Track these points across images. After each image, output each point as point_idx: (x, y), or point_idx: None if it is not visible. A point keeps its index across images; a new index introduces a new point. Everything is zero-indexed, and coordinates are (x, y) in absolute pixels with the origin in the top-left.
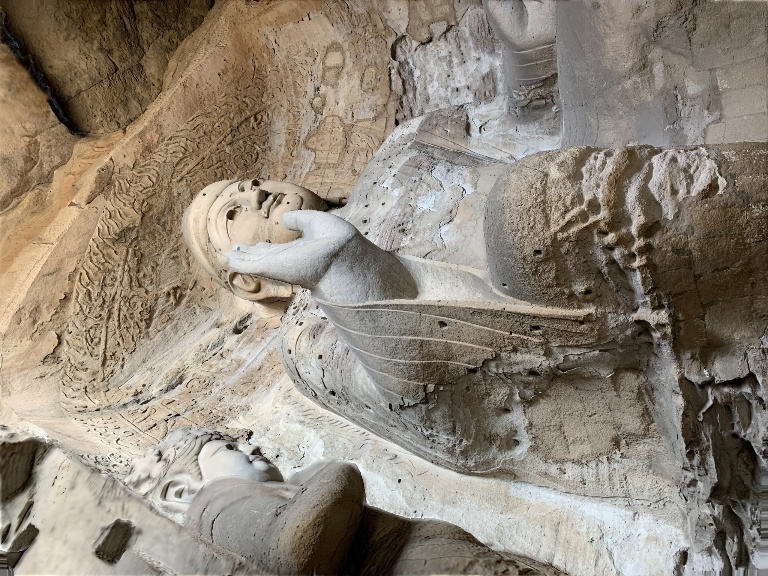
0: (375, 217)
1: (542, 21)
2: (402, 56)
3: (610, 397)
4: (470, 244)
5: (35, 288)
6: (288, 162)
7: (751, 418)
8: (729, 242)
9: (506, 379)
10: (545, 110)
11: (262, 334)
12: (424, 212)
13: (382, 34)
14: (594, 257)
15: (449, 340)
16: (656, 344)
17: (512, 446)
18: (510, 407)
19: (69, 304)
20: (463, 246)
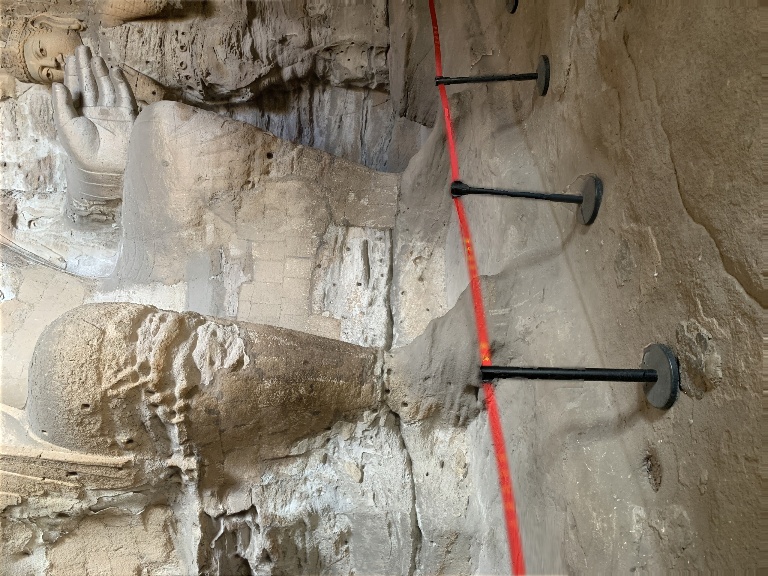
0: None
1: (113, 152)
2: None
3: (138, 531)
4: (2, 359)
5: None
6: None
7: (250, 540)
8: (247, 406)
9: (30, 523)
10: (105, 224)
11: None
12: None
13: None
14: (139, 412)
15: None
16: (184, 484)
17: None
18: (30, 551)
19: None
20: None
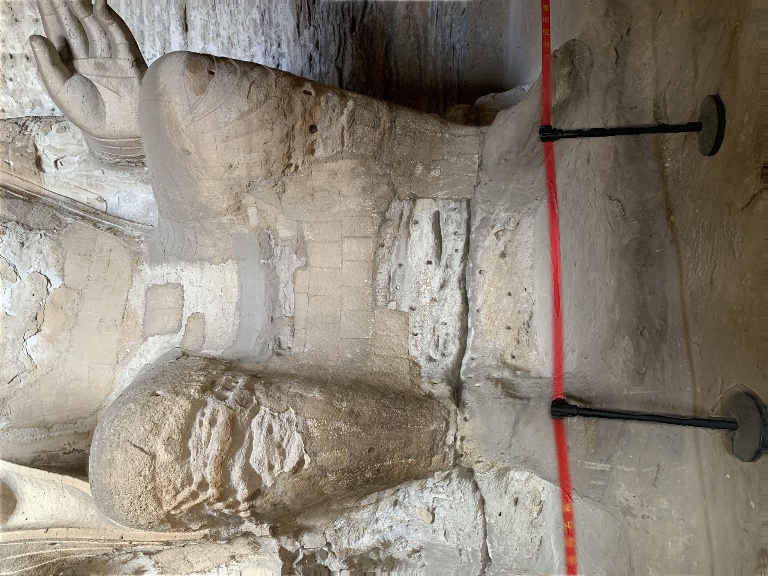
0: None
1: (123, 117)
2: None
3: None
4: (67, 362)
5: None
6: None
7: None
8: (312, 495)
9: None
10: (136, 167)
11: None
12: None
13: None
14: (206, 513)
15: (63, 549)
16: None
17: (141, 574)
18: (135, 558)
19: None
20: (59, 364)
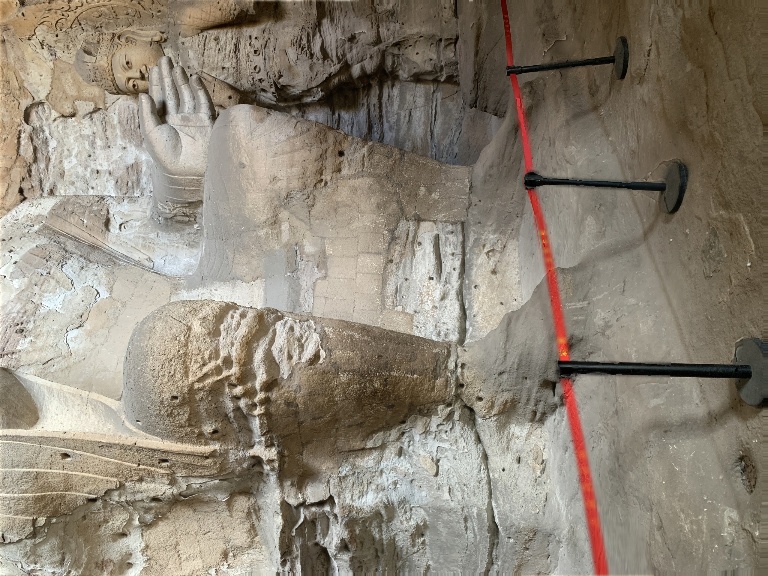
0: None
1: (194, 156)
2: (37, 122)
3: (224, 517)
4: (100, 354)
5: None
6: None
7: (328, 529)
8: (324, 399)
9: (127, 506)
10: (187, 225)
11: None
12: (49, 312)
13: (15, 93)
14: (223, 404)
15: (70, 471)
16: (266, 474)
17: (125, 570)
18: (128, 532)
19: None
20: (91, 355)
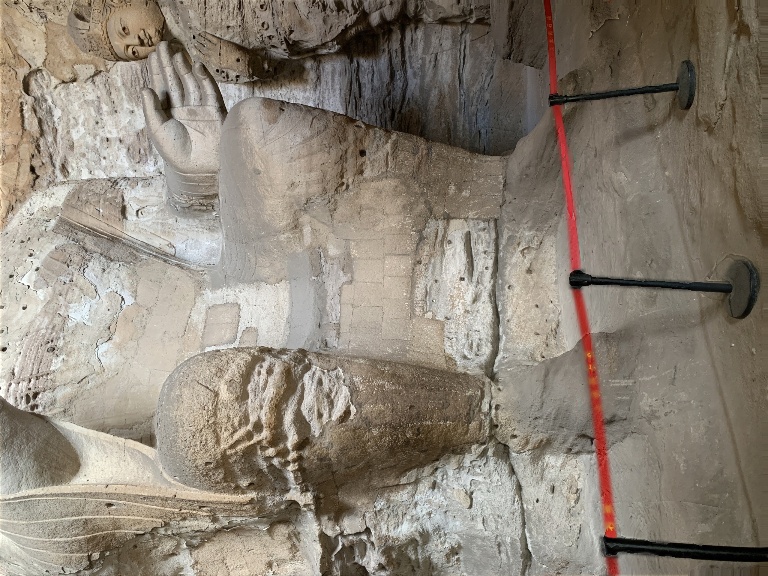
0: (15, 327)
1: (205, 154)
2: (38, 91)
3: (266, 539)
4: (131, 367)
5: None
6: None
7: (366, 551)
8: (356, 452)
9: (174, 536)
10: (205, 212)
11: None
12: (77, 326)
13: (10, 62)
14: (257, 463)
15: (117, 516)
16: (303, 511)
17: None
18: (177, 552)
19: None
20: (124, 369)
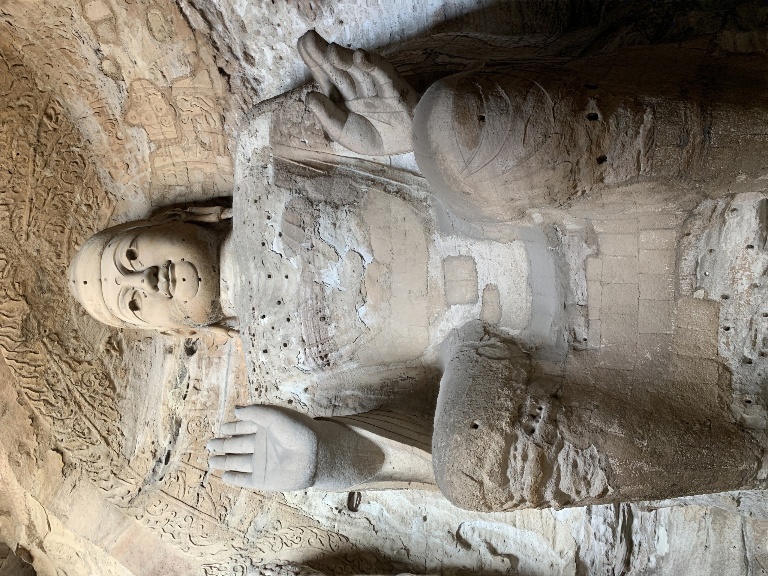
0: (287, 298)
1: (399, 142)
2: None
3: None
4: (391, 325)
5: (4, 433)
6: (120, 148)
7: None
8: None
9: None
10: None
11: (216, 353)
12: (334, 293)
13: None
14: None
15: None
16: None
17: None
18: None
19: (40, 421)
20: (385, 327)
